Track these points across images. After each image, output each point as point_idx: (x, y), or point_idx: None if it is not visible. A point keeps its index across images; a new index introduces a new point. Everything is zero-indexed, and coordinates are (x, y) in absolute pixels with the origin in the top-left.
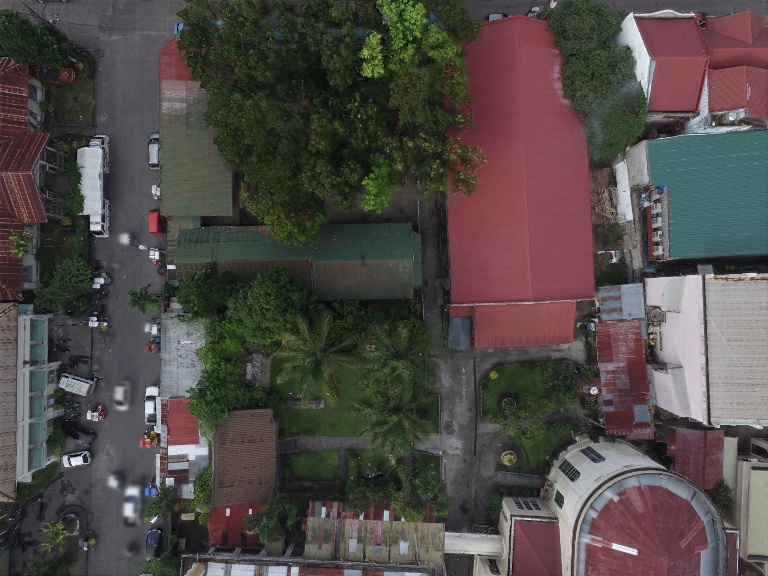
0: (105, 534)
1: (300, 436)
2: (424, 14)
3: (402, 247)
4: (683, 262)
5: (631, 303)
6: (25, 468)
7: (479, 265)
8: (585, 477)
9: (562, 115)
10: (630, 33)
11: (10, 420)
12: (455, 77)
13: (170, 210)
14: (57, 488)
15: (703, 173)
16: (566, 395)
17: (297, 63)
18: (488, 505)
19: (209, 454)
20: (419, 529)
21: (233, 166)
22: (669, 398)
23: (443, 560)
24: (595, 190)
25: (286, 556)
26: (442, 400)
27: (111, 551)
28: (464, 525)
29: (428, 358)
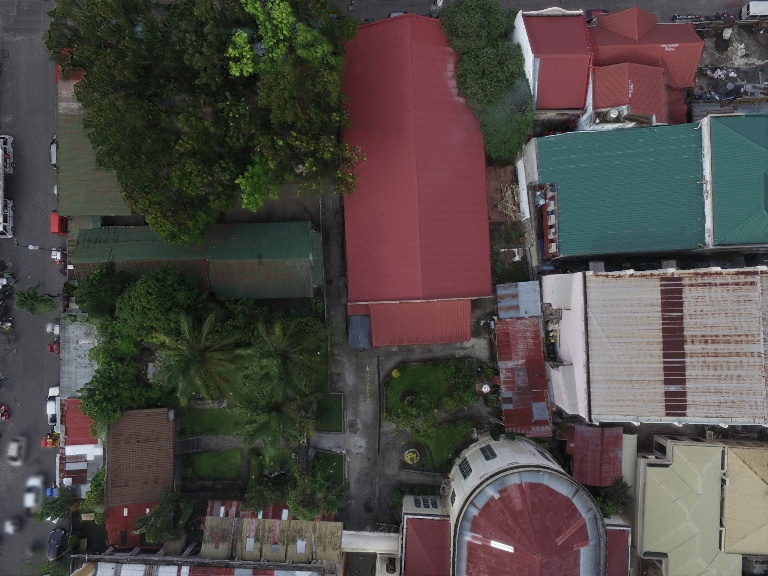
0: (9, 535)
1: (203, 435)
2: (290, 12)
3: (300, 246)
4: (578, 259)
5: (528, 301)
6: None
7: (374, 263)
8: (474, 475)
9: (456, 113)
10: (520, 31)
11: None
12: (325, 75)
13: (67, 210)
14: None
15: (590, 170)
16: (465, 393)
17: (164, 62)
18: (392, 503)
19: (103, 454)
20: (317, 528)
21: (103, 165)
22: (561, 395)
23: (340, 559)
24: (498, 188)
25: (182, 555)
26: (346, 399)
27: (15, 552)
28: (368, 524)
29: (332, 357)
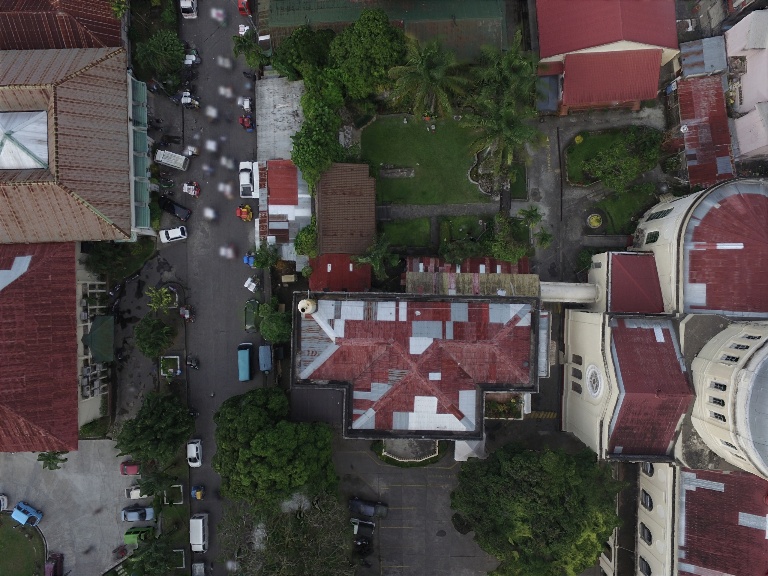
0: (203, 308)
1: (392, 205)
2: None
3: (490, 8)
4: None
5: (713, 55)
6: (133, 221)
7: (568, 17)
8: (681, 204)
9: None
10: None
11: (123, 159)
12: None
13: None
14: (153, 266)
15: None
16: (651, 150)
17: None
18: (576, 268)
19: (312, 205)
20: (515, 279)
21: None
22: (756, 134)
23: None
24: None
25: None
26: (528, 168)
27: (209, 324)
28: None
29: None
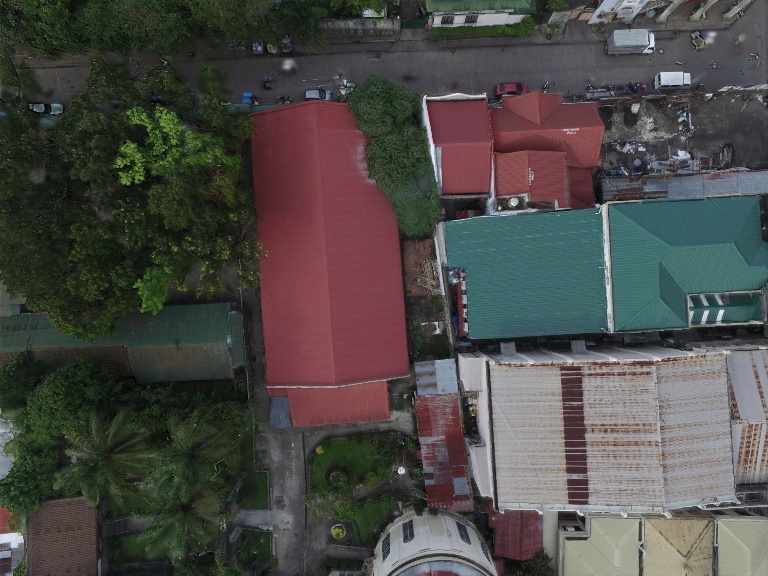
0: None
1: (130, 517)
2: (178, 122)
3: (218, 329)
4: None
5: (445, 378)
6: None
7: (289, 347)
8: (389, 559)
9: (368, 195)
10: (426, 115)
11: None
12: (218, 181)
13: None
14: None
15: (497, 254)
16: (387, 470)
17: None
18: None
19: (24, 545)
20: None
21: None
22: (476, 475)
23: None
24: (418, 262)
25: None
26: (272, 475)
27: None
28: None
29: (257, 434)
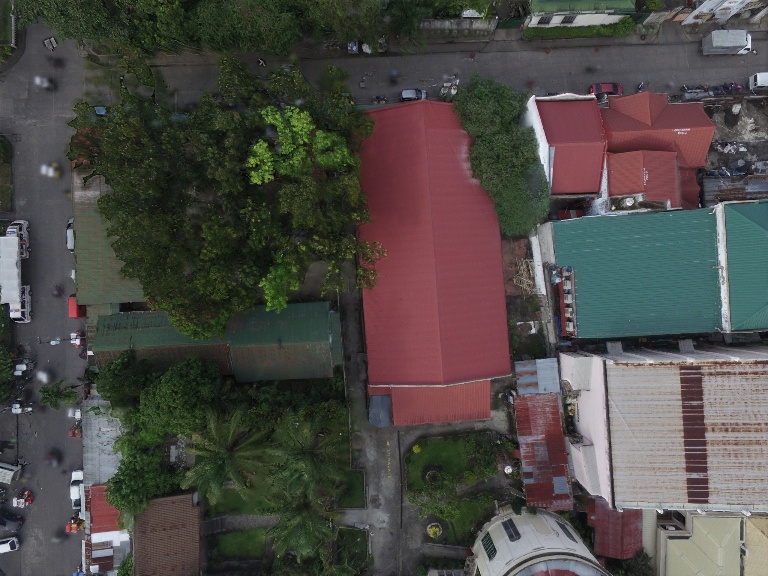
0: None
1: (227, 515)
2: (311, 121)
3: (319, 328)
4: None
5: (546, 378)
6: None
7: (394, 346)
8: (499, 558)
9: (472, 195)
10: (533, 115)
11: None
12: (346, 180)
13: (86, 299)
14: None
15: (607, 254)
16: (486, 469)
17: (186, 173)
18: None
19: (130, 543)
20: None
21: (127, 275)
22: (582, 474)
23: None
24: (513, 261)
25: None
26: (367, 474)
27: None
28: None
29: (352, 433)
